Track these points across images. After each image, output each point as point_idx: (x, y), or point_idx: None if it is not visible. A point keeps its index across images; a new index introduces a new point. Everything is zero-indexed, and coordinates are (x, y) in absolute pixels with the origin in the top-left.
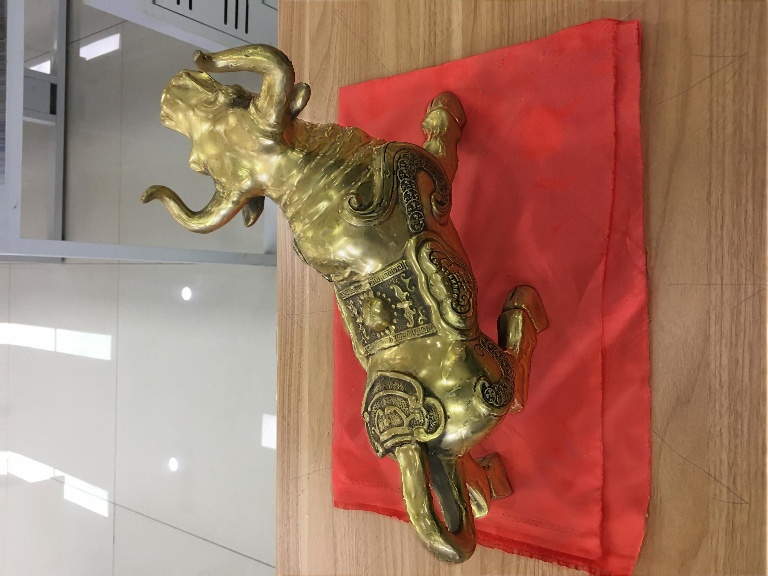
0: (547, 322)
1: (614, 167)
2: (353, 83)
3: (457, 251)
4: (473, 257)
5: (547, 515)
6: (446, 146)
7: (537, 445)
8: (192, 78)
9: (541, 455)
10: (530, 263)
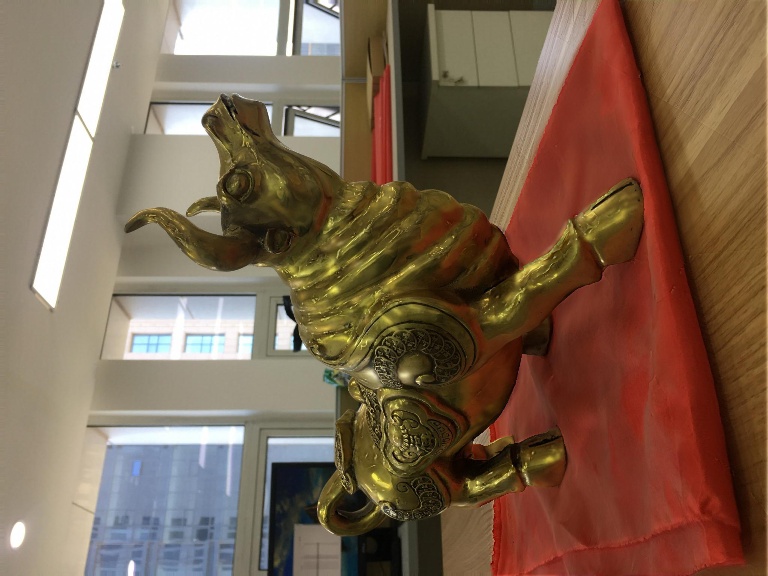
0: (557, 485)
1: (632, 543)
2: None
3: (458, 405)
4: (566, 363)
5: (513, 522)
6: (521, 308)
7: (526, 500)
8: (216, 131)
9: None
10: (570, 447)
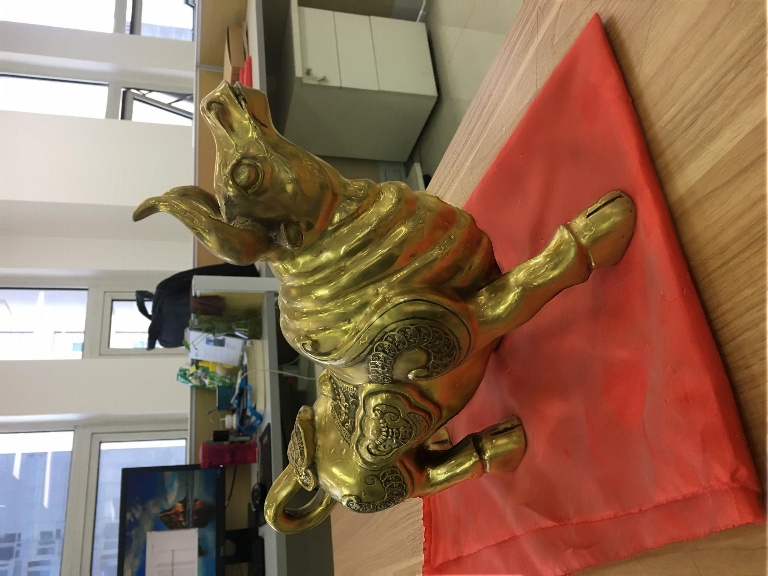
0: (513, 470)
1: (619, 515)
2: (614, 24)
3: (436, 397)
4: (526, 357)
5: None
6: (517, 306)
7: (465, 487)
8: (221, 118)
9: (462, 493)
10: (535, 434)
